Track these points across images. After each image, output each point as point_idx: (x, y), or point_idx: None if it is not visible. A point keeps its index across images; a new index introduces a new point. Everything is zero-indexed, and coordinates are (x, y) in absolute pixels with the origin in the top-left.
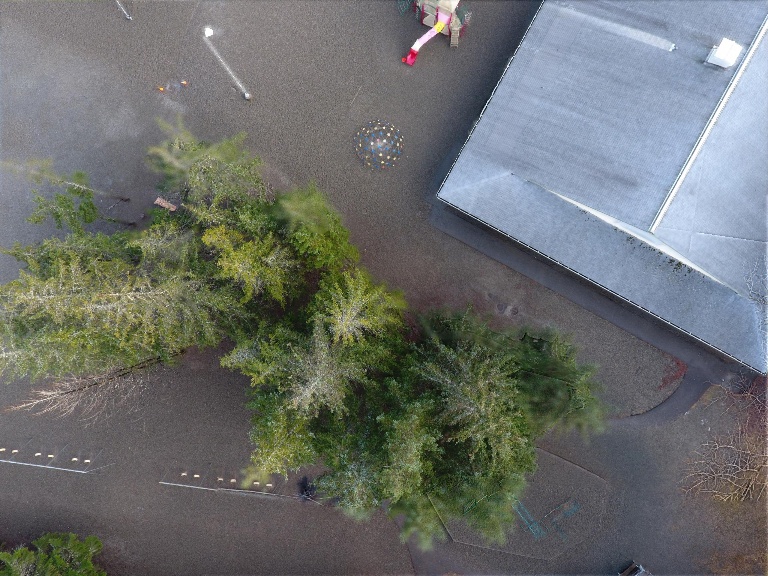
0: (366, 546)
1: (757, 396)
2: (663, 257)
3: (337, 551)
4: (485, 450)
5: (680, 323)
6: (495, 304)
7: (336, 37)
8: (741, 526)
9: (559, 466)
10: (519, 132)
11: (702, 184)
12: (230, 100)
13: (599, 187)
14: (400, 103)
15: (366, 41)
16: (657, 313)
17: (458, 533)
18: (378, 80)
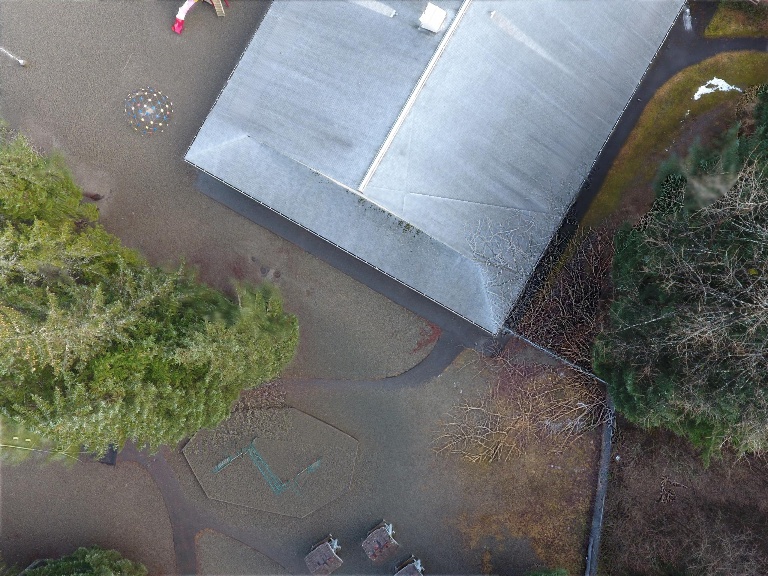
0: (126, 502)
1: (508, 360)
2: (392, 219)
3: (97, 506)
4: (241, 409)
5: (414, 284)
6: (258, 267)
7: (109, 6)
8: (489, 487)
9: (312, 426)
10: (258, 96)
11: (413, 145)
12: (7, 66)
13: (320, 148)
14: (169, 71)
15: (138, 10)
16: (392, 274)
17: (212, 490)
18: (148, 48)
